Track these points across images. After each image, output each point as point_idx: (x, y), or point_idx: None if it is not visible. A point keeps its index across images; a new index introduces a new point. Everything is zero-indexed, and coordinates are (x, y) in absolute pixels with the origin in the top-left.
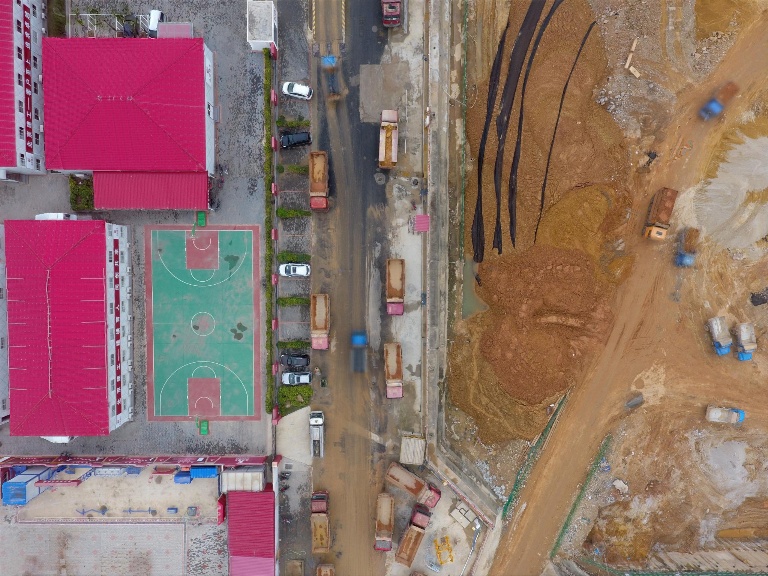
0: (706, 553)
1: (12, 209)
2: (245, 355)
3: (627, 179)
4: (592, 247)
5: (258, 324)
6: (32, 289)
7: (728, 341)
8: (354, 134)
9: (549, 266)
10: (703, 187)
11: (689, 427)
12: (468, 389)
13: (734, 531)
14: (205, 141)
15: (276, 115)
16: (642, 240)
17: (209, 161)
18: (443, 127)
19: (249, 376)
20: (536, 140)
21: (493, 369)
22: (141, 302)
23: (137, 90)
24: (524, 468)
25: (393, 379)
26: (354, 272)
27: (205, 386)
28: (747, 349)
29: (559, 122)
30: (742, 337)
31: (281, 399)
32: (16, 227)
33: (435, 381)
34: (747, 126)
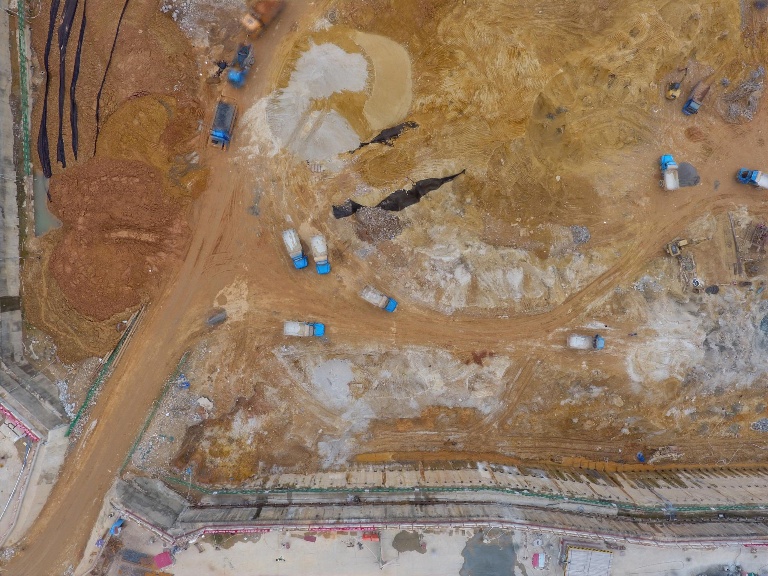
0: (321, 474)
1: None
2: None
3: (197, 90)
4: (156, 159)
5: None
6: None
7: (297, 253)
8: None
9: (103, 177)
10: (275, 97)
11: (276, 343)
12: (39, 307)
13: (372, 455)
14: None
15: None
16: (216, 153)
17: None
18: None
19: None
20: (96, 50)
21: (58, 285)
22: None
23: None
24: (95, 385)
25: None
26: None
27: None
28: (317, 261)
29: (120, 31)
30: (318, 250)
31: None
32: None
33: None
34: (318, 34)
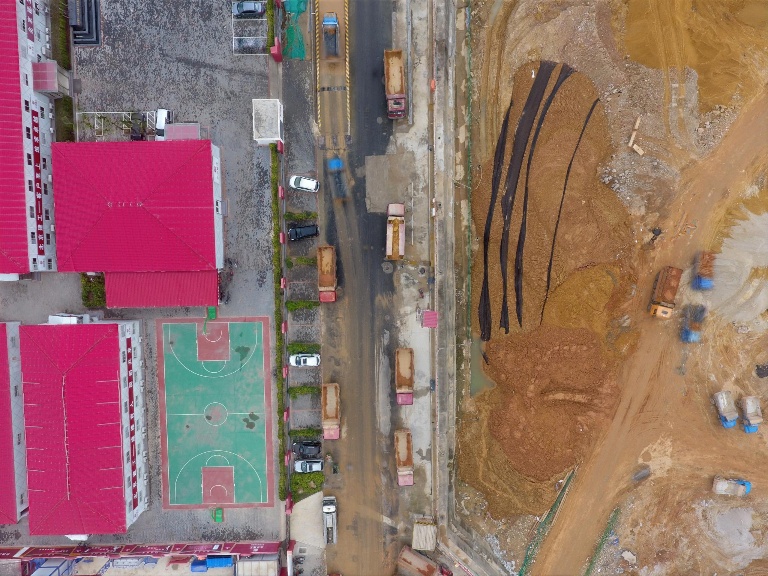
0: None
1: (25, 306)
2: (258, 444)
3: (632, 256)
4: (598, 325)
5: (270, 413)
6: (48, 393)
7: (734, 416)
8: (361, 224)
9: (556, 347)
10: (708, 263)
11: (696, 498)
12: (477, 466)
13: None
14: (214, 241)
15: (283, 208)
16: (647, 316)
17: (218, 257)
18: (449, 212)
19: (262, 464)
20: (541, 220)
21: (502, 447)
22: (154, 394)
23: (146, 195)
24: (534, 543)
25: (404, 466)
26: (363, 360)
27: (219, 474)
28: (753, 423)
29: (564, 202)
30: (748, 410)
31: (294, 486)
32: (31, 332)
33: (445, 465)
34: (751, 201)
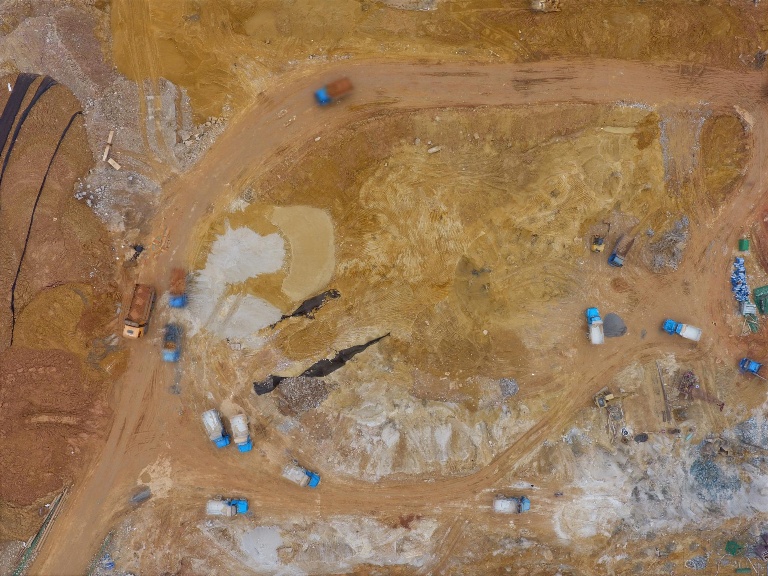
0: None
1: None
2: None
3: (114, 274)
4: (74, 346)
5: None
6: None
7: (217, 435)
8: None
9: (19, 369)
10: (193, 279)
11: (201, 518)
12: None
13: None
14: None
15: None
16: None
17: None
18: None
19: None
20: (11, 239)
21: None
22: None
23: None
24: (19, 570)
25: None
26: None
27: None
28: (237, 442)
29: (34, 219)
30: (239, 429)
31: None
32: None
33: None
34: (234, 215)
